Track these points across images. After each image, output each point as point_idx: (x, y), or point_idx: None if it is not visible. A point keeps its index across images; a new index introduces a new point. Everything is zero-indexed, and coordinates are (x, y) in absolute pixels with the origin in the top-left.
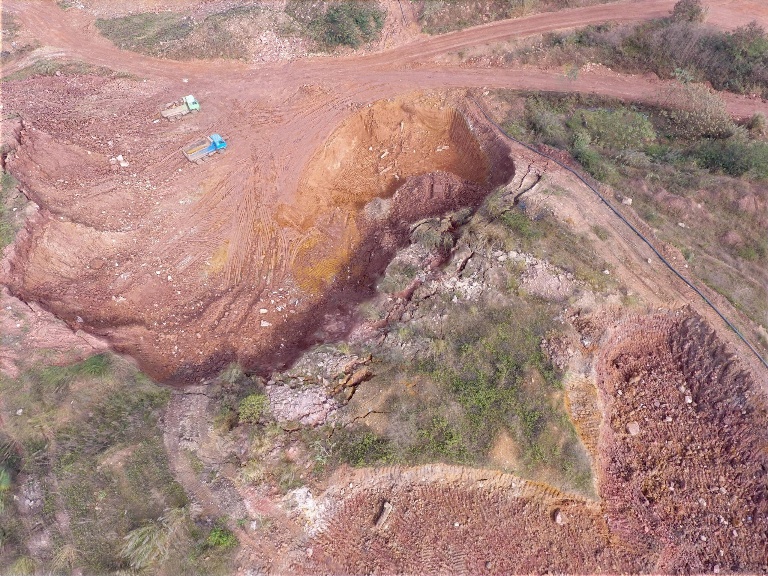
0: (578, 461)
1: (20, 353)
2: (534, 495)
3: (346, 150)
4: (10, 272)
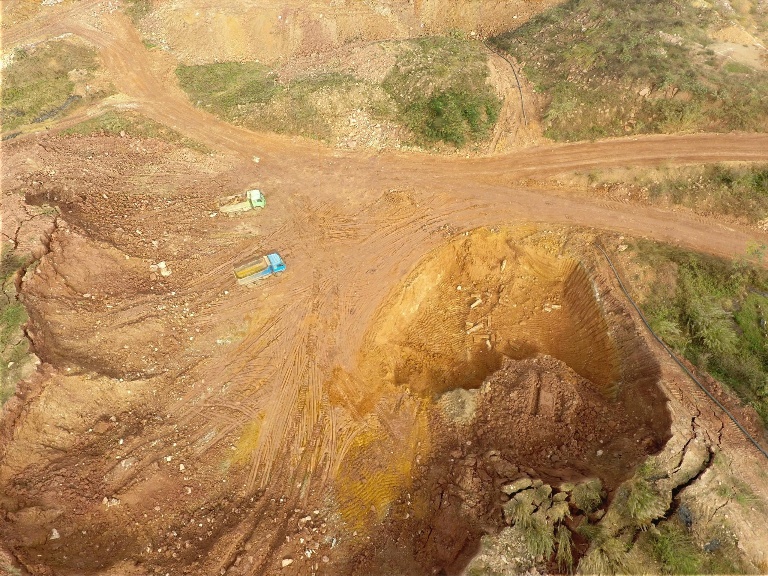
0: None
1: None
2: None
3: (429, 288)
4: None
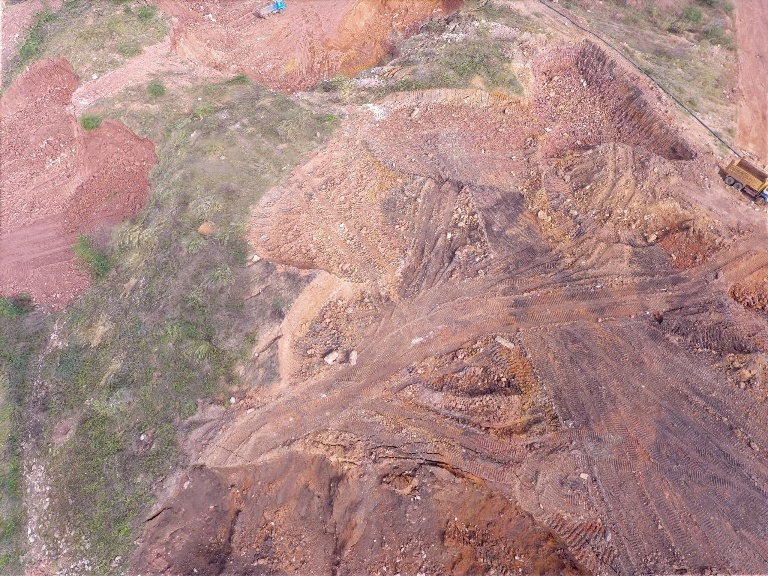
0: (517, 86)
1: None
2: (494, 103)
3: (368, 14)
4: None
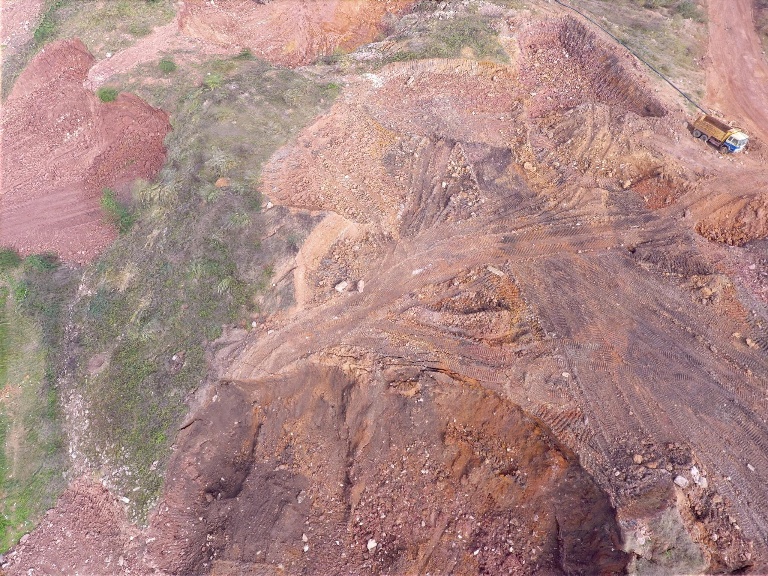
0: (504, 55)
1: (199, 57)
2: (483, 71)
3: None
4: (178, 29)
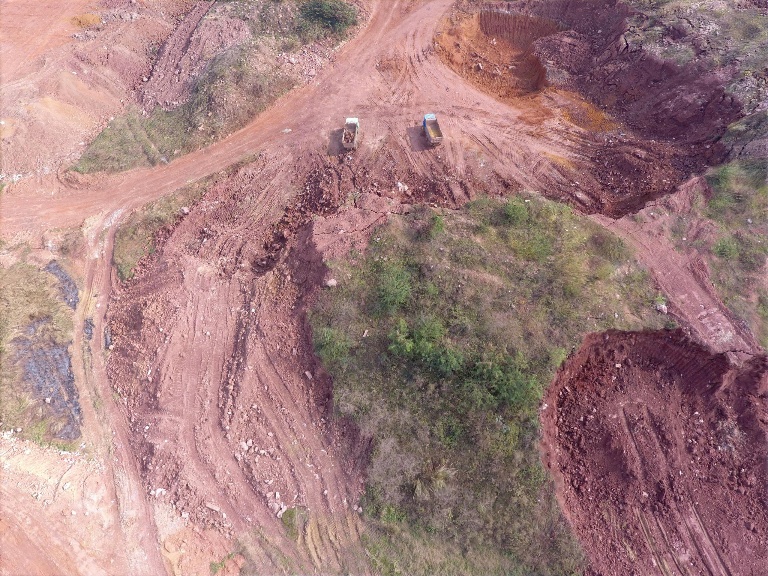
0: None
1: None
2: None
3: None
4: None
